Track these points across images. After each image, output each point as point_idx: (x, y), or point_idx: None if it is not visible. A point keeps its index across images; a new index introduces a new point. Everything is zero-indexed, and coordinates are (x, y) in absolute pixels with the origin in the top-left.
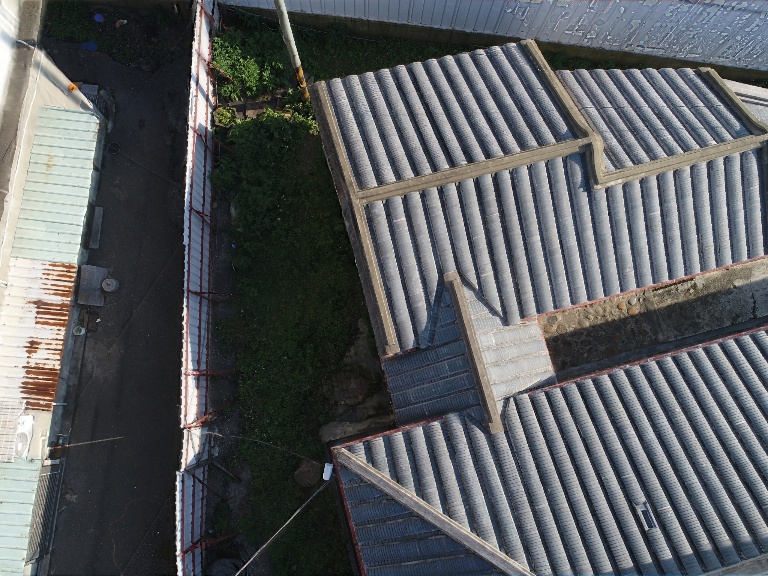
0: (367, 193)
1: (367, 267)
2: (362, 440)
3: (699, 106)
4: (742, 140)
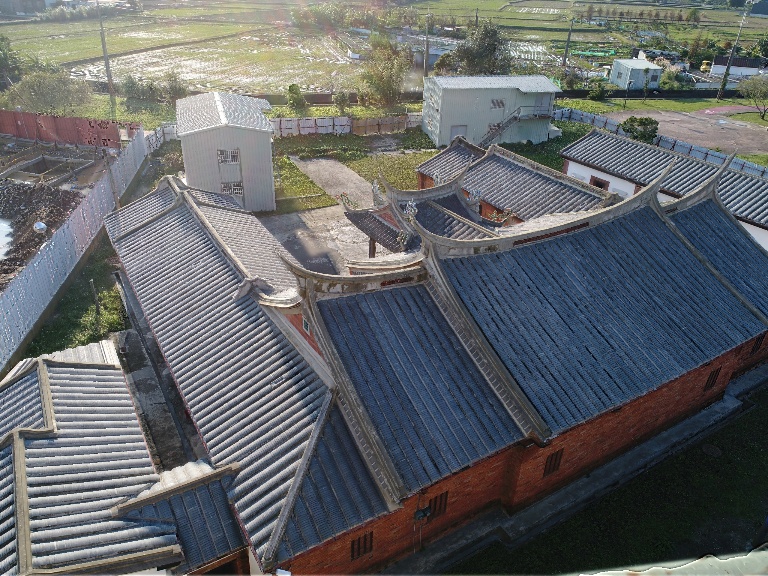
0: (23, 565)
1: (97, 568)
2: (254, 553)
3: (4, 399)
4: (39, 370)
